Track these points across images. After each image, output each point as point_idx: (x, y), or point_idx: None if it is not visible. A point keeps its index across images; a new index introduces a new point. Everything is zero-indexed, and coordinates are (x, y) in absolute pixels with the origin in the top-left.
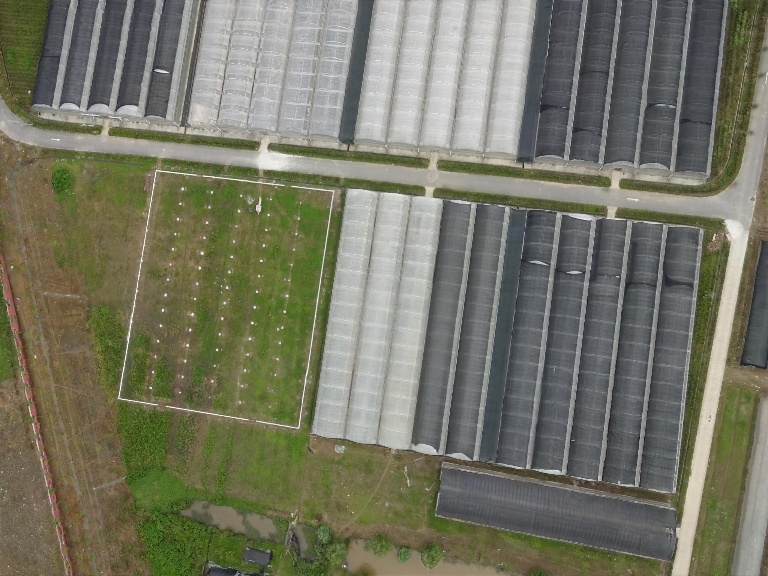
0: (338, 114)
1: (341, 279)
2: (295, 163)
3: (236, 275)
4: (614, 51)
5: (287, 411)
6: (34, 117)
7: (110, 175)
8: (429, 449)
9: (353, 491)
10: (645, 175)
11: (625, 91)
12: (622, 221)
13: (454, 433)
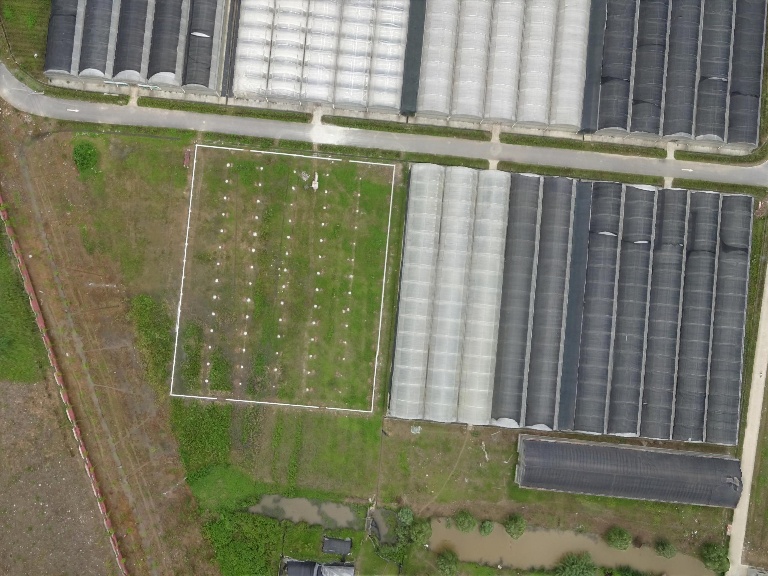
0: (399, 84)
1: (413, 256)
2: (352, 136)
3: (295, 256)
4: (668, 24)
5: (359, 395)
6: (44, 85)
7: (142, 150)
8: (511, 422)
9: (432, 470)
10: (697, 146)
11: (682, 64)
12: (683, 191)
13: (534, 405)
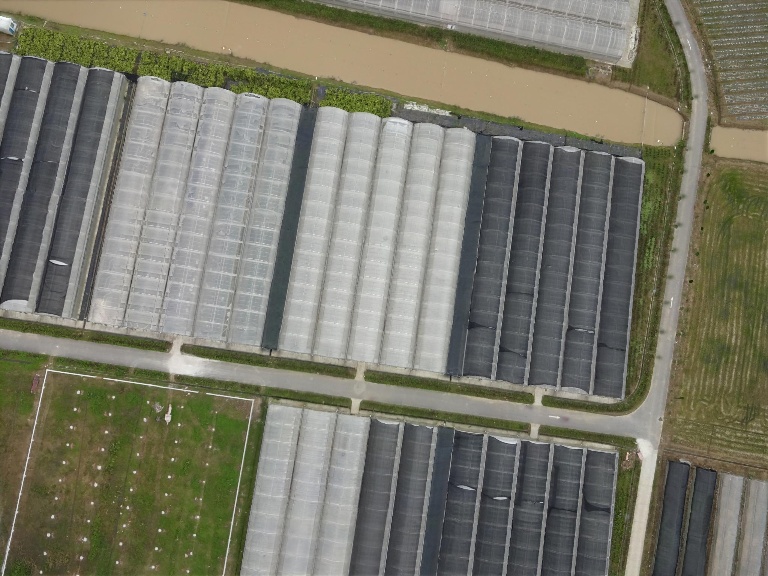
0: (261, 321)
1: (260, 505)
2: (211, 368)
3: (139, 493)
4: (538, 272)
5: None
6: None
7: None
8: None
9: None
10: (565, 392)
11: (549, 314)
12: (546, 445)
13: None
